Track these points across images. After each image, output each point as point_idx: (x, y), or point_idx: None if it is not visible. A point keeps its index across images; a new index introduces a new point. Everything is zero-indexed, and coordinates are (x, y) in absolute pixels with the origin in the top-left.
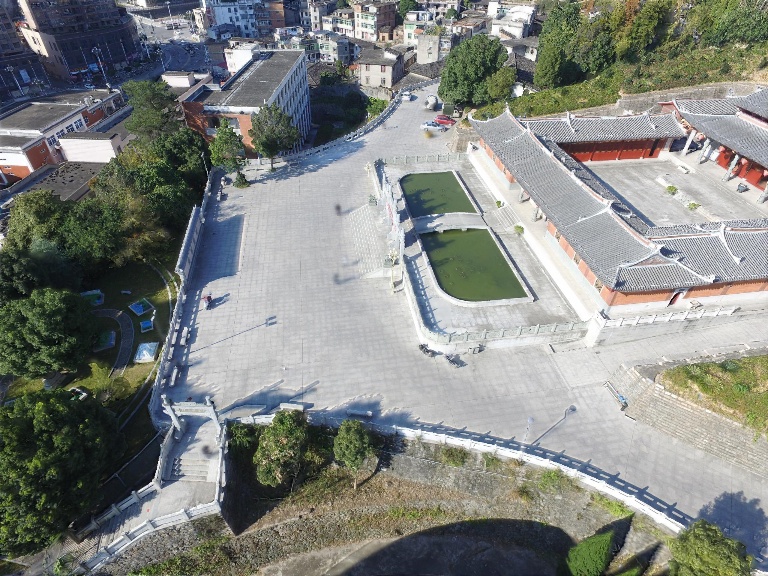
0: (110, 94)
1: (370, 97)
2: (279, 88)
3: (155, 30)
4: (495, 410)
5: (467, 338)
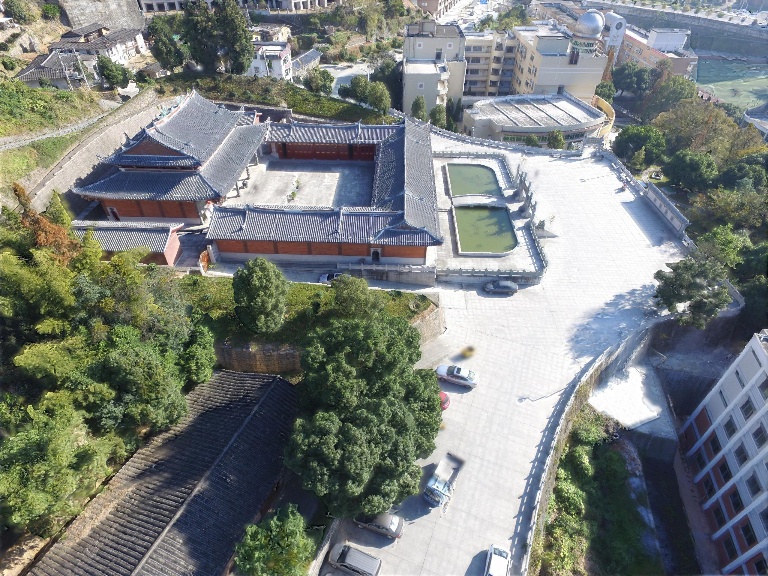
0: None
1: None
2: None
3: None
4: (476, 150)
5: (485, 155)
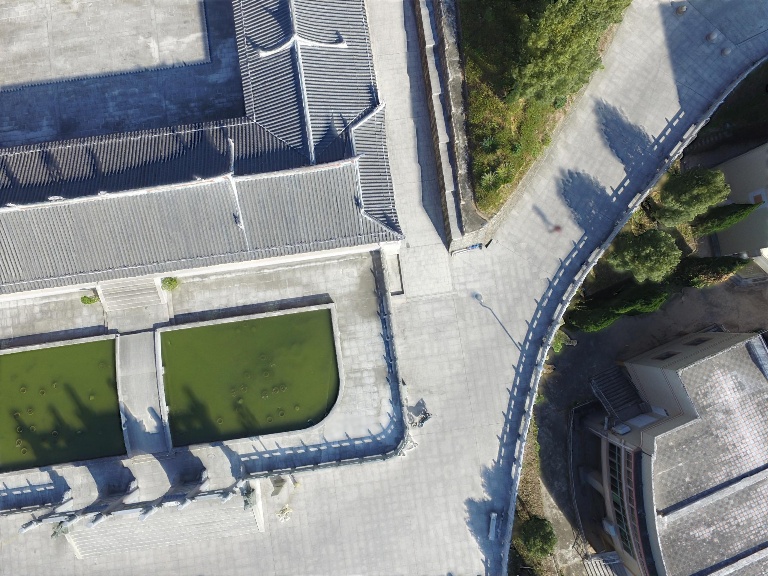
0: None
1: None
2: None
3: None
4: (483, 379)
5: None
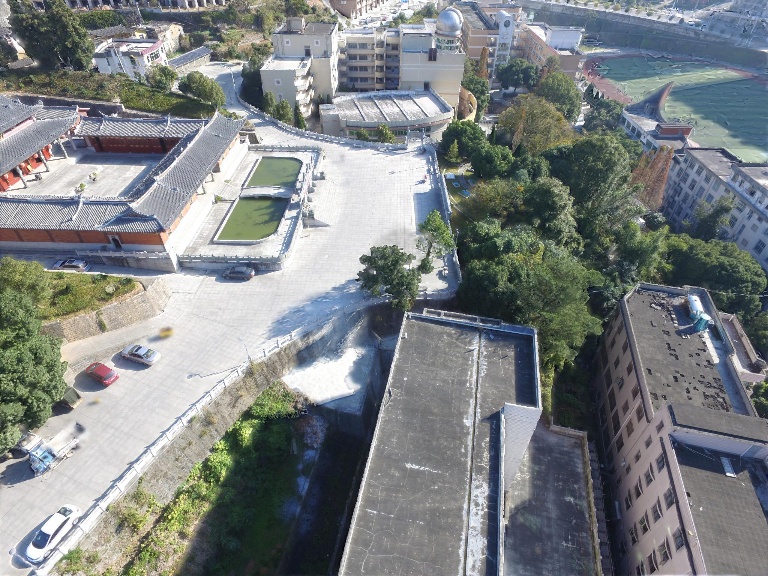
0: None
1: None
2: None
3: None
4: (308, 144)
5: (305, 149)
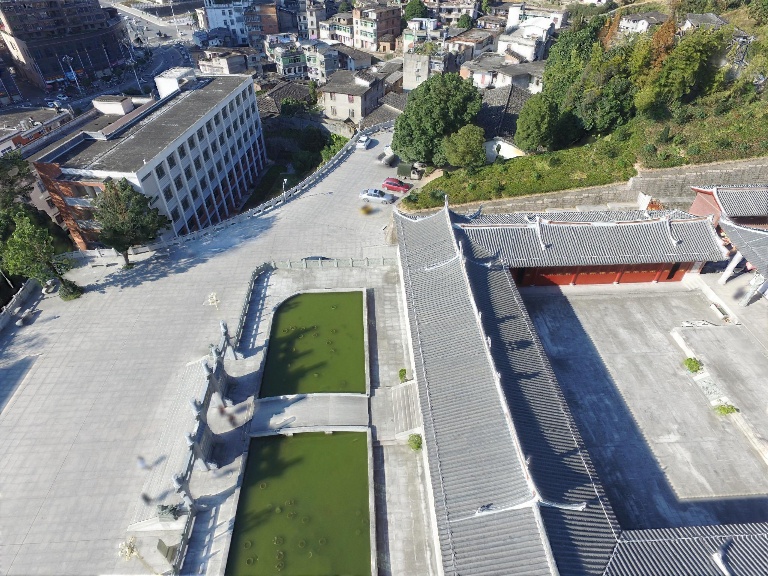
0: (56, 115)
1: (332, 133)
2: (182, 137)
3: (145, 34)
4: None
5: None
